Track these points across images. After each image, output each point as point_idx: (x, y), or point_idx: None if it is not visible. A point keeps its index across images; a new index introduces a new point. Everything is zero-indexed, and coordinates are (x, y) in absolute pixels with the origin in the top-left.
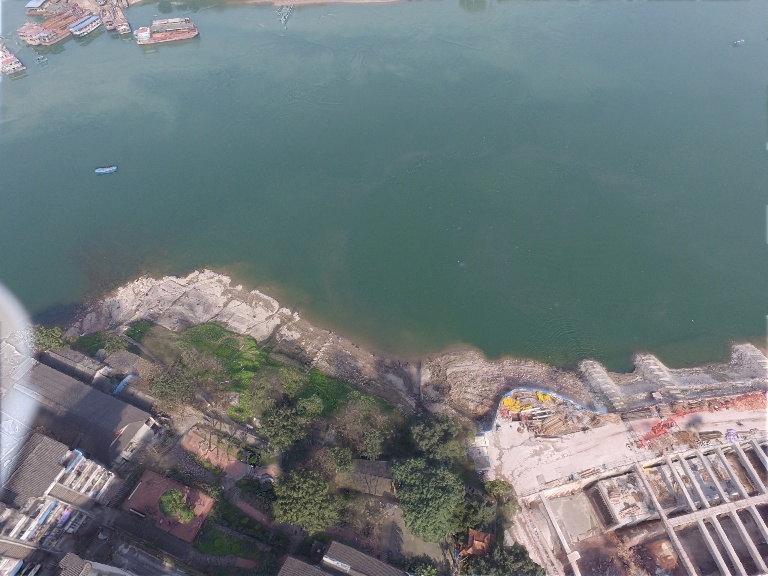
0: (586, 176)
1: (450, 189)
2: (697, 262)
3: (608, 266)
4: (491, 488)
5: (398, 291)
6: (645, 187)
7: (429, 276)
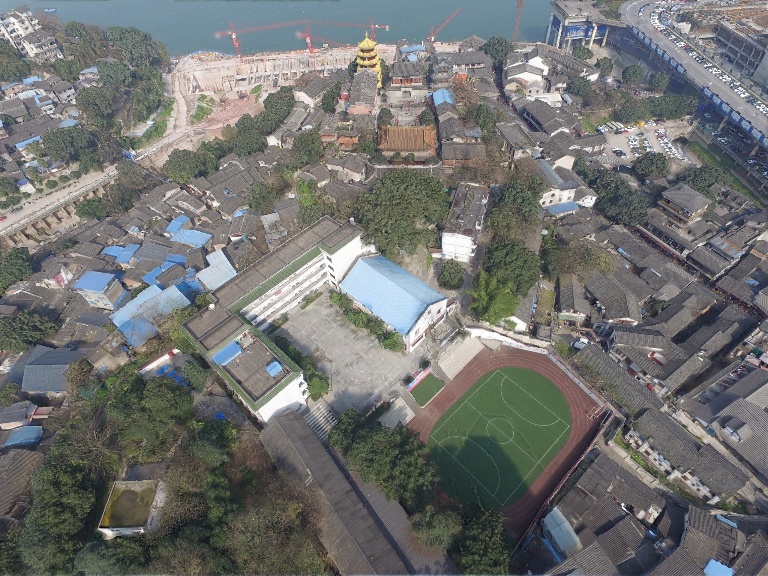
0: (303, 5)
1: (228, 11)
2: (330, 28)
3: (285, 31)
4: (158, 53)
5: (178, 41)
6: (331, 8)
7: (196, 36)
